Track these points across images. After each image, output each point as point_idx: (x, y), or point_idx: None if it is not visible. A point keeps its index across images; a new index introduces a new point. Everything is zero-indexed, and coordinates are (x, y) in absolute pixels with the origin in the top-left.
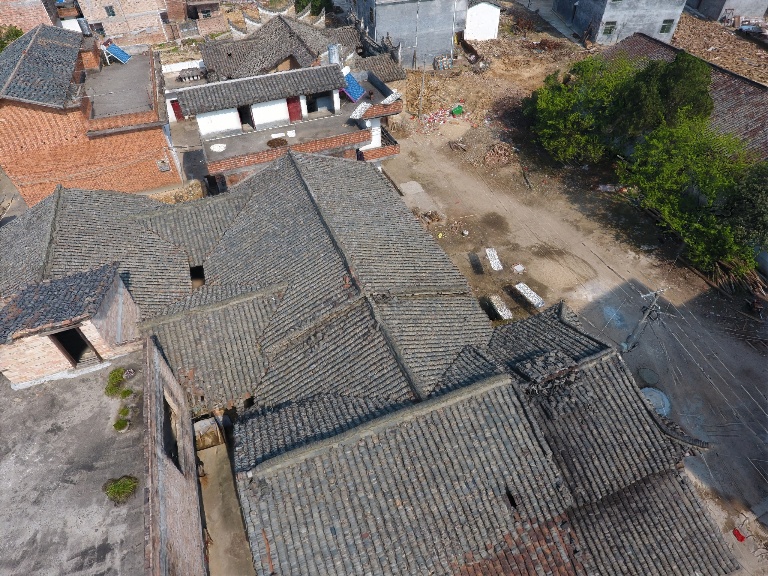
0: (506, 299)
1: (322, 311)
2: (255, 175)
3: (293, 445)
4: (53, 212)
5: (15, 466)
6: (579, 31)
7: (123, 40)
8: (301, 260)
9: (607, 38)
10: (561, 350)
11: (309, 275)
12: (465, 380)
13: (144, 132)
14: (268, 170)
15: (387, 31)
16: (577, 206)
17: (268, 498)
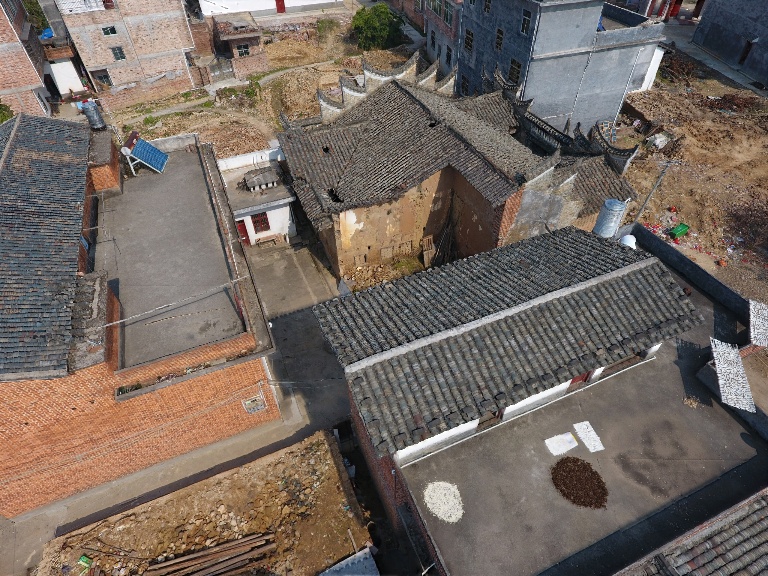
0: None
1: None
2: None
3: None
4: None
5: None
6: (760, 78)
7: (136, 90)
8: None
9: None
10: None
11: None
12: None
13: None
14: None
15: (538, 95)
16: None
17: None
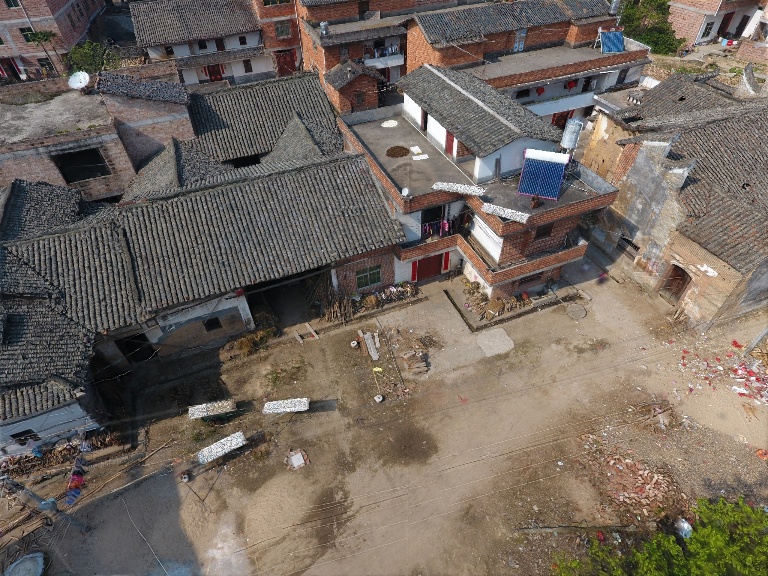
0: (244, 433)
1: None
2: None
3: (24, 198)
4: (277, 79)
5: None
6: None
7: None
8: None
9: None
10: (1, 351)
11: None
12: (4, 269)
13: None
14: None
15: None
16: None
17: (0, 193)
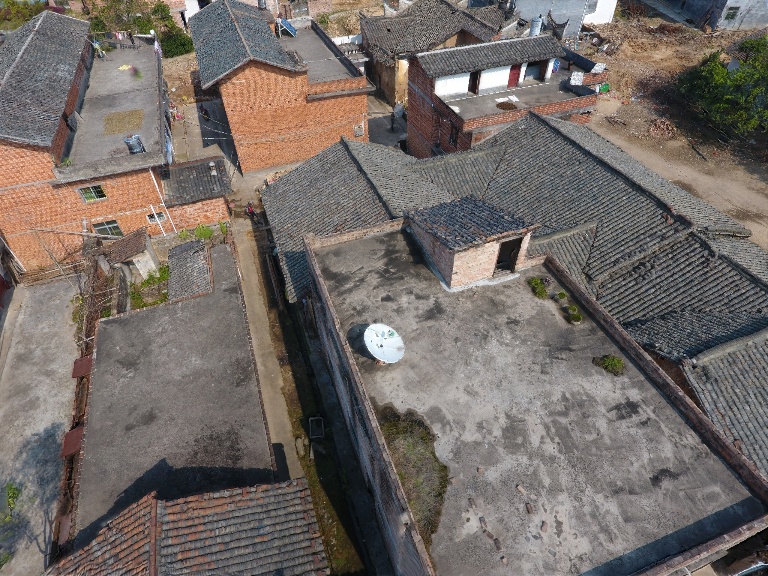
0: None
1: (650, 244)
2: (498, 134)
3: (706, 343)
4: None
5: (502, 347)
6: (692, 17)
7: None
8: (600, 203)
9: (728, 23)
10: None
11: (618, 215)
12: None
13: (352, 97)
14: (512, 129)
15: (523, 12)
16: (757, 176)
17: (714, 380)
